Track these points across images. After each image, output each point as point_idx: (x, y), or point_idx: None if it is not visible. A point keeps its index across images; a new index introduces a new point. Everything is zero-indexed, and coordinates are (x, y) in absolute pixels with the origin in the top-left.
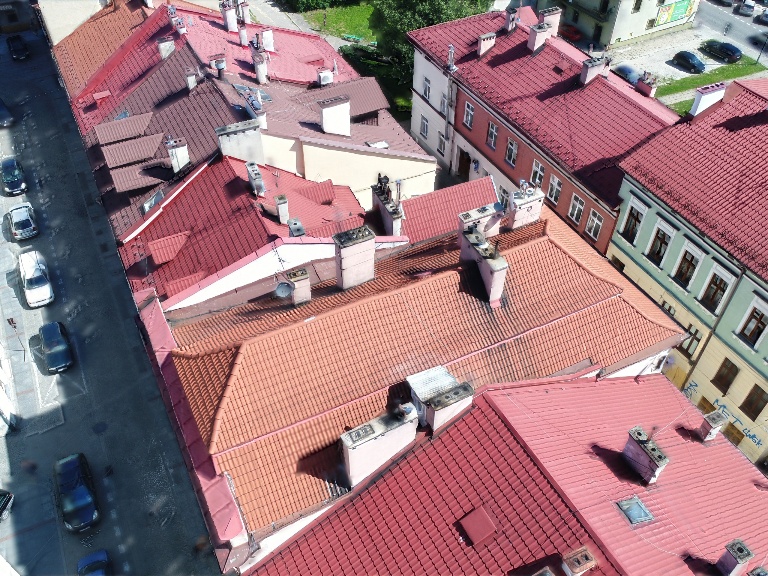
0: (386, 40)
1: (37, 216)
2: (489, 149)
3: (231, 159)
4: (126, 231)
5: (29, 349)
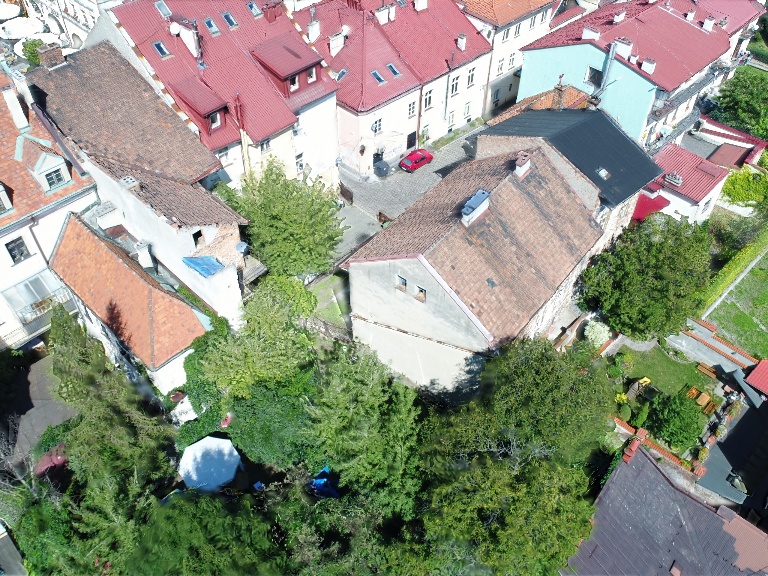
0: None
1: None
2: None
3: None
4: None
5: None
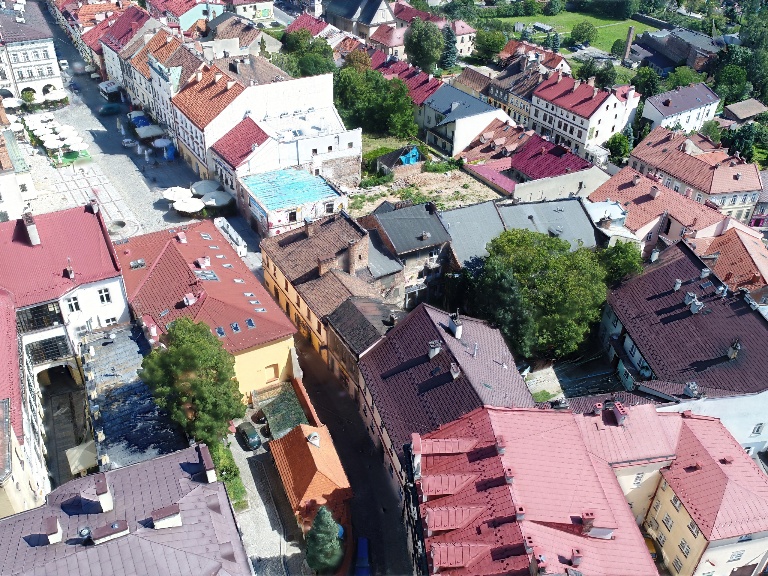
0: (143, 3)
1: None
2: None
3: None
4: None
5: None
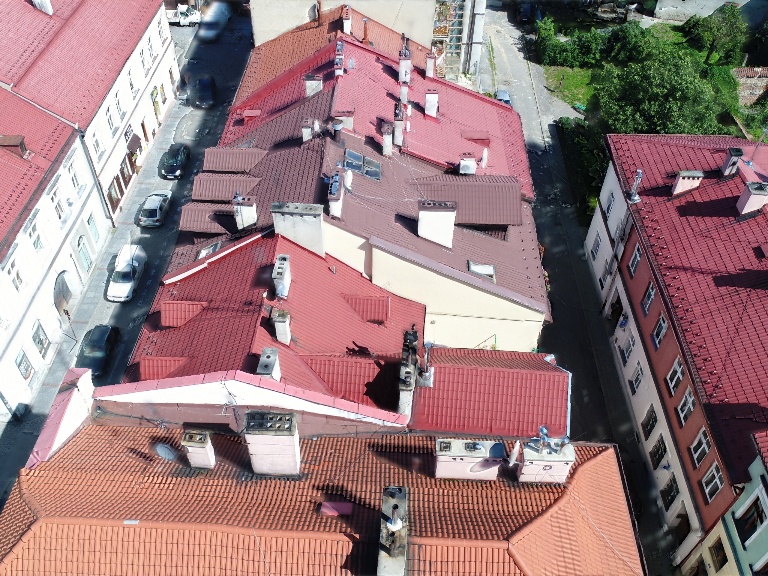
0: (594, 131)
1: (172, 207)
2: (641, 311)
3: (284, 239)
4: (171, 272)
5: (81, 341)
